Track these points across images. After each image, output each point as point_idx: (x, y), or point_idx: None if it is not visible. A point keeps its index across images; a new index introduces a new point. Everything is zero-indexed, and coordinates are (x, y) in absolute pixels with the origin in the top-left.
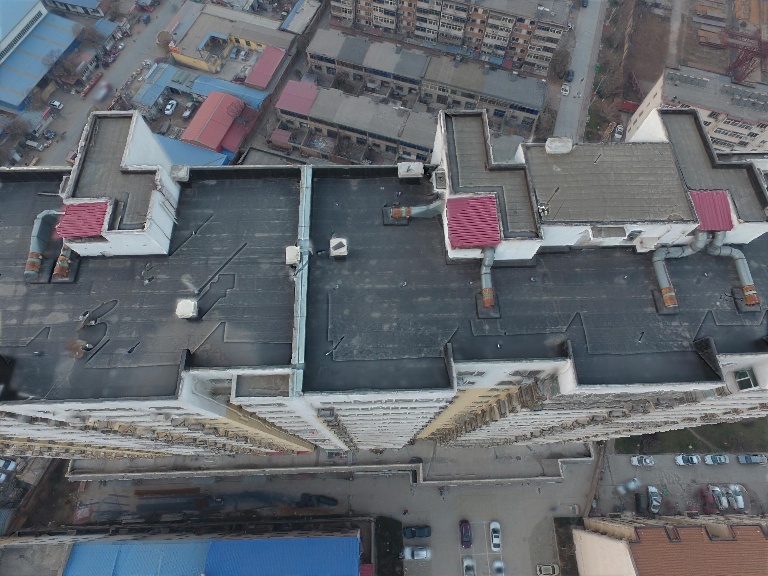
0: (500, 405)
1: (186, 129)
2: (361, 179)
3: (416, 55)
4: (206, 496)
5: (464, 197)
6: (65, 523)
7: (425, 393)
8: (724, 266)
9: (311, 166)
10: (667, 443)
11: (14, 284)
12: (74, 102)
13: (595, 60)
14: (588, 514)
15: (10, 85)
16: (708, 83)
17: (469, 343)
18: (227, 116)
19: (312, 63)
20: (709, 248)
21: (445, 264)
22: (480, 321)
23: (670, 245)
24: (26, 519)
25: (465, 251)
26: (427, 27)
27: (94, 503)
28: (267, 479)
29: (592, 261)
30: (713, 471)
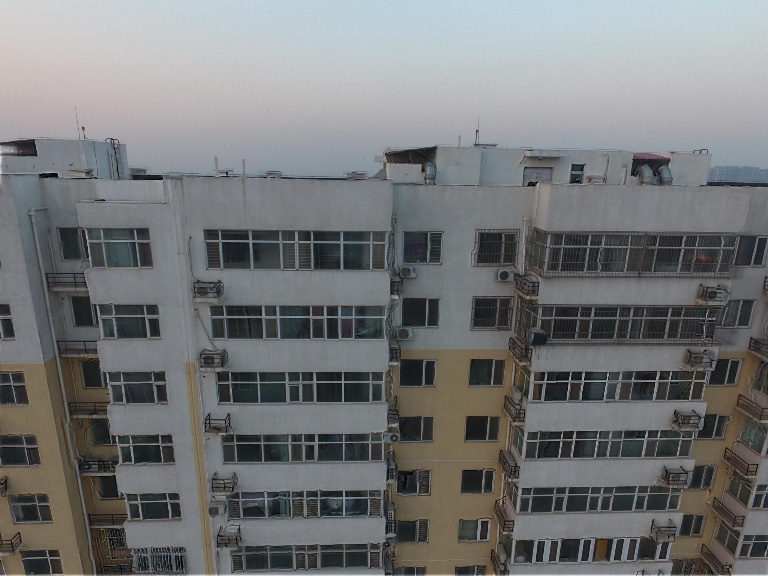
0: (504, 456)
1: None
2: None
3: None
4: None
5: None
6: None
7: (350, 182)
8: None
9: None
10: None
11: None
12: None
13: None
14: None
15: None
16: None
17: None
18: None
19: None
20: None
21: None
22: None
23: None
24: None
25: (405, 167)
26: None
27: None
28: None
29: None
30: None
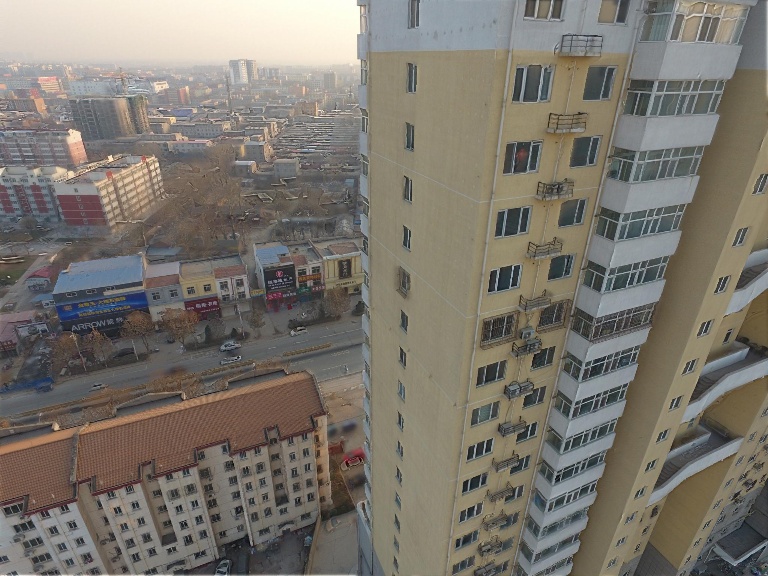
0: None
1: None
2: None
3: None
4: None
5: None
6: None
7: None
8: None
9: None
10: None
11: None
12: None
13: None
14: None
15: None
16: None
17: None
18: None
19: None
20: None
21: None
22: None
23: None
24: None
25: None
26: None
27: None
28: None
29: None
30: None
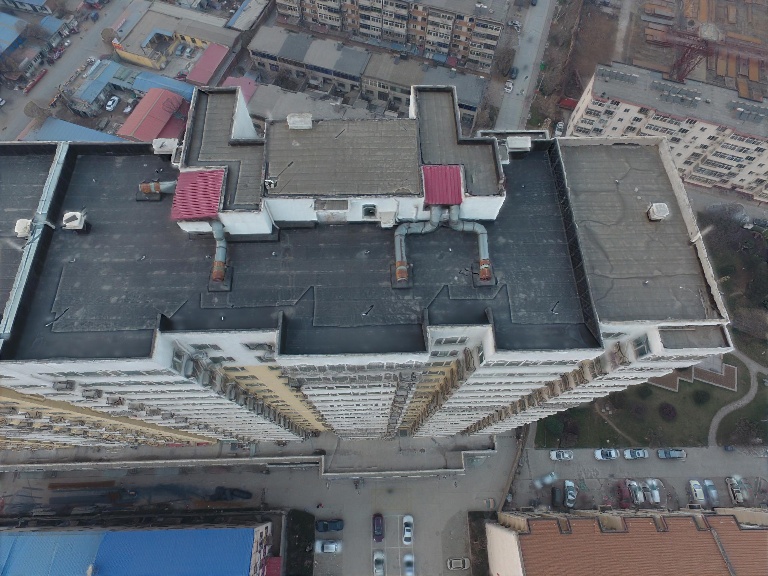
0: None
1: (123, 125)
2: (127, 156)
3: (357, 52)
4: (120, 489)
5: (196, 171)
6: None
7: (123, 362)
8: (471, 242)
9: (68, 142)
10: (587, 438)
11: None
12: (17, 98)
13: (540, 58)
14: (502, 508)
15: None
16: (639, 79)
17: (194, 315)
18: (164, 112)
19: (254, 60)
20: (450, 223)
21: (188, 239)
22: (210, 294)
23: (415, 220)
24: None
25: (193, 224)
26: (371, 24)
27: (7, 496)
28: (182, 472)
29: (338, 236)
30: (632, 466)
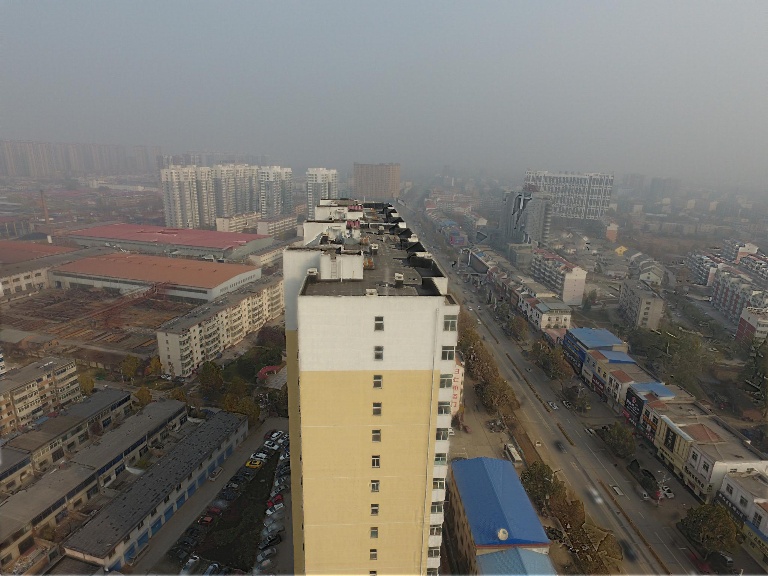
0: None
1: None
2: None
3: None
4: None
5: None
6: None
7: None
8: None
9: None
10: None
11: None
12: None
13: None
14: None
15: None
16: None
17: None
18: None
19: None
20: None
21: None
22: None
23: None
24: None
25: None
26: None
27: None
28: None
29: None
30: None
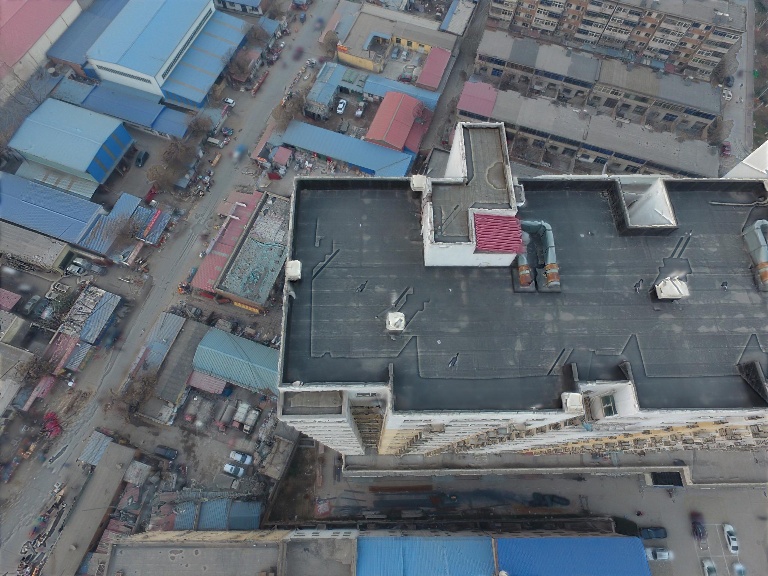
0: None
1: (370, 129)
2: None
3: (586, 58)
4: (440, 493)
5: None
6: (307, 517)
7: None
8: None
9: None
10: None
11: (745, 292)
12: (245, 100)
13: (752, 65)
14: None
15: (190, 82)
16: None
17: None
18: (409, 116)
19: None
20: None
21: None
22: None
23: None
24: (270, 513)
25: None
26: (590, 30)
27: (331, 498)
28: None
29: None
30: None
